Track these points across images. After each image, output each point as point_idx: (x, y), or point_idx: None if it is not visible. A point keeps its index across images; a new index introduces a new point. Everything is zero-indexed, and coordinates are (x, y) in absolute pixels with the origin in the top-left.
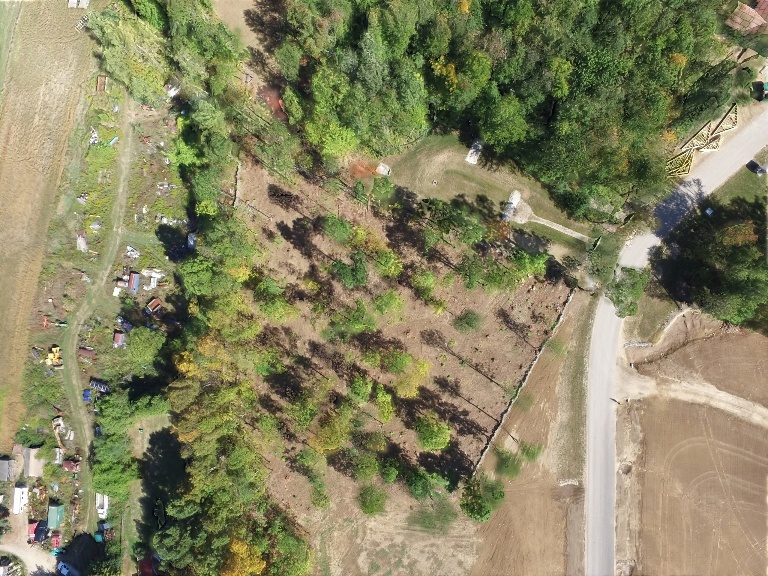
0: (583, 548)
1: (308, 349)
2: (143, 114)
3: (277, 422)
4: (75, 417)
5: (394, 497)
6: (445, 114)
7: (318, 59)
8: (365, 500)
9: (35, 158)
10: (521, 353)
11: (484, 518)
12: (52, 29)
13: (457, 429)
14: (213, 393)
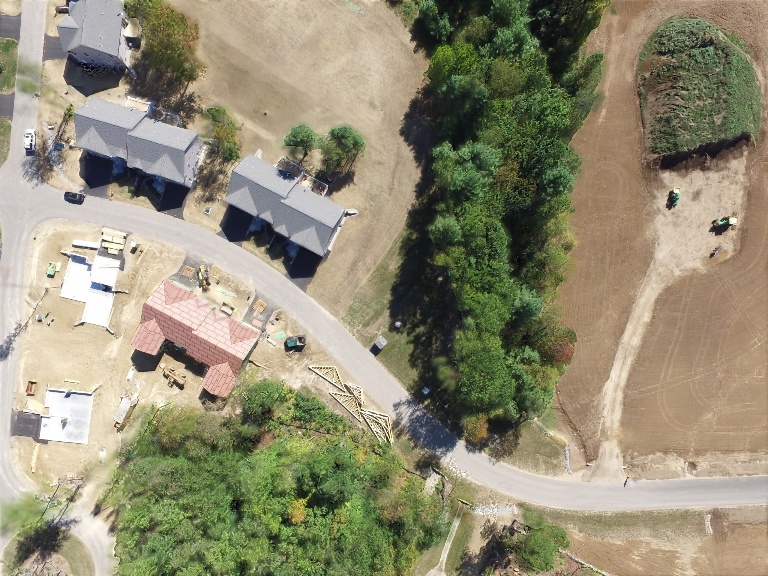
0: None
1: None
2: None
3: None
4: None
5: None
6: None
7: None
8: None
9: None
10: None
11: None
12: None
13: None
14: None
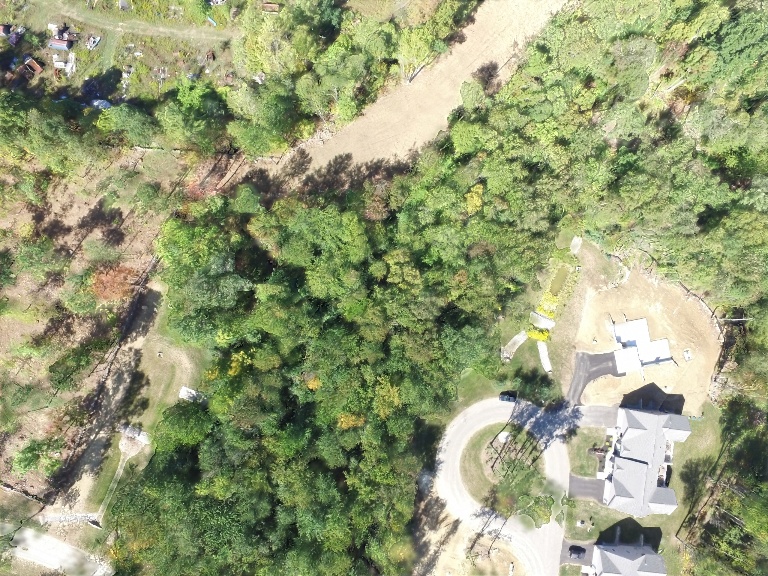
0: None
1: None
2: None
3: None
4: None
5: None
6: None
7: (249, 232)
8: None
9: None
10: None
11: None
12: None
13: None
14: None
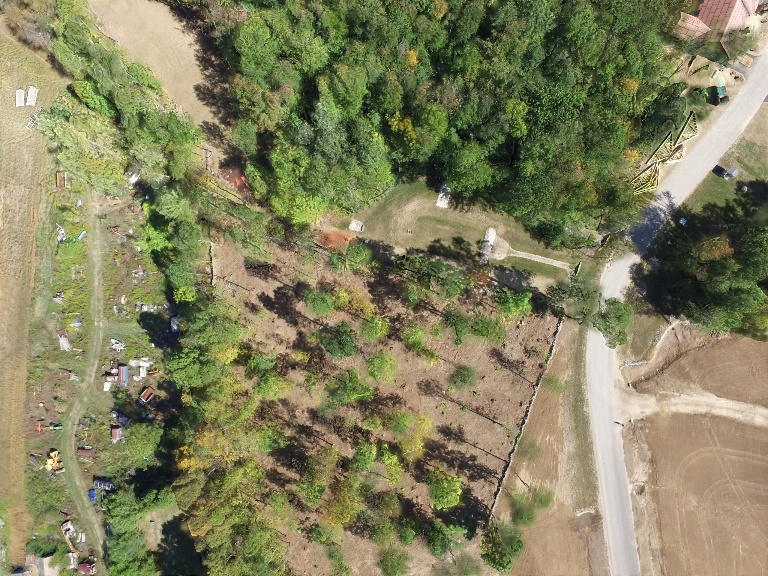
0: (609, 574)
1: (307, 417)
2: (107, 204)
3: (287, 495)
4: (84, 519)
5: (415, 552)
6: (409, 163)
7: (274, 132)
8: (386, 567)
9: (5, 263)
10: (519, 390)
11: (506, 569)
12: (3, 131)
13: (467, 475)
14: (219, 479)
